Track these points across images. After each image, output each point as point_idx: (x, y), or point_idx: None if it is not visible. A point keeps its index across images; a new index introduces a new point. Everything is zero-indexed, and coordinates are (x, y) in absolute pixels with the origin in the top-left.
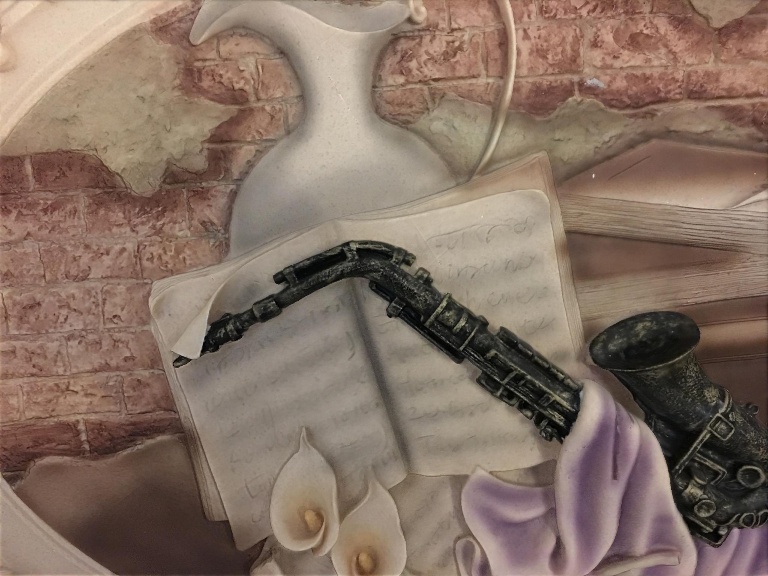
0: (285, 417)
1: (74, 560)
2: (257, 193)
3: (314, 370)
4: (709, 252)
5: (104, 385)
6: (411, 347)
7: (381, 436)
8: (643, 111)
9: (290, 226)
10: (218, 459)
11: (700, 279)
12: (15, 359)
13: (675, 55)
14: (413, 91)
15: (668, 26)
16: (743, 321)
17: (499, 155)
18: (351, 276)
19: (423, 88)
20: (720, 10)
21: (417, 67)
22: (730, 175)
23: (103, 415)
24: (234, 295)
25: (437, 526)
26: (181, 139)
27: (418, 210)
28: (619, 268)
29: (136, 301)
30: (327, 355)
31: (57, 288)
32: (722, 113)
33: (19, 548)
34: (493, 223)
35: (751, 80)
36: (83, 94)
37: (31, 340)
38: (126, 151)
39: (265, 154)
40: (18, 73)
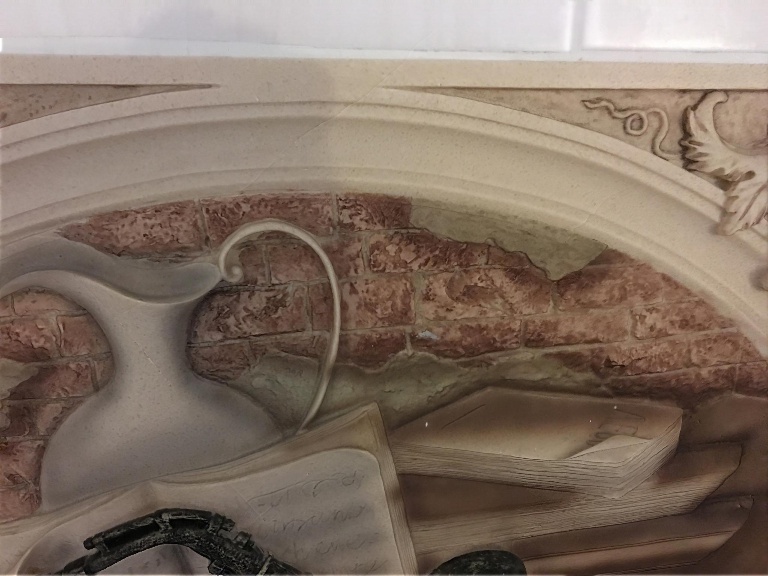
0: None
1: None
2: (65, 452)
3: None
4: (544, 493)
5: None
6: None
7: None
8: (479, 359)
9: (103, 485)
10: None
11: (535, 517)
12: None
13: (511, 306)
14: (232, 348)
15: (504, 278)
16: (577, 553)
17: (327, 407)
18: None
19: (243, 345)
20: (558, 263)
21: (235, 324)
22: (565, 424)
23: None
24: (46, 553)
25: None
26: None
27: (238, 471)
28: (453, 509)
29: None
30: None
31: None
32: (560, 360)
33: None
34: (319, 478)
35: (590, 327)
36: None
37: None
38: None
39: (73, 411)
40: None
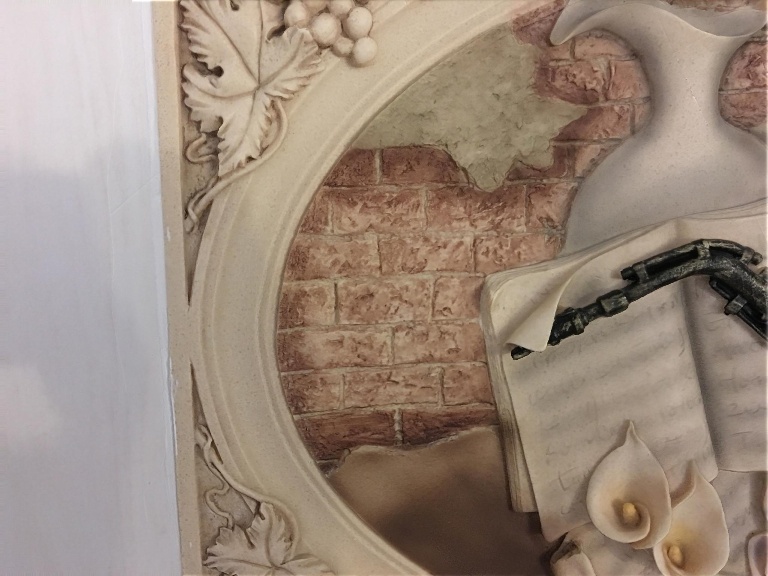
0: (610, 411)
1: (373, 549)
2: (601, 191)
3: (646, 365)
4: None
5: (426, 376)
6: (741, 344)
7: (703, 431)
8: None
9: (632, 224)
10: (534, 451)
11: None
12: (341, 349)
13: None
14: (758, 95)
15: None
16: None
17: None
18: (699, 273)
19: (767, 92)
20: None
21: (763, 72)
22: None
23: (420, 406)
24: (573, 290)
25: (732, 522)
26: (531, 136)
27: (761, 211)
28: None
29: (468, 294)
30: (660, 351)
31: (391, 280)
32: None
33: (321, 536)
34: None
35: None
36: (441, 90)
37: (359, 330)
38: (476, 147)
39: (610, 153)
40: (376, 68)
